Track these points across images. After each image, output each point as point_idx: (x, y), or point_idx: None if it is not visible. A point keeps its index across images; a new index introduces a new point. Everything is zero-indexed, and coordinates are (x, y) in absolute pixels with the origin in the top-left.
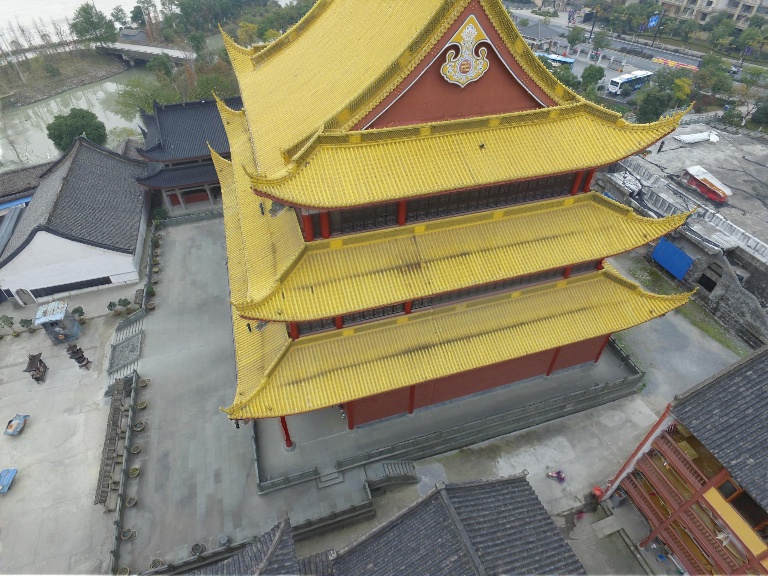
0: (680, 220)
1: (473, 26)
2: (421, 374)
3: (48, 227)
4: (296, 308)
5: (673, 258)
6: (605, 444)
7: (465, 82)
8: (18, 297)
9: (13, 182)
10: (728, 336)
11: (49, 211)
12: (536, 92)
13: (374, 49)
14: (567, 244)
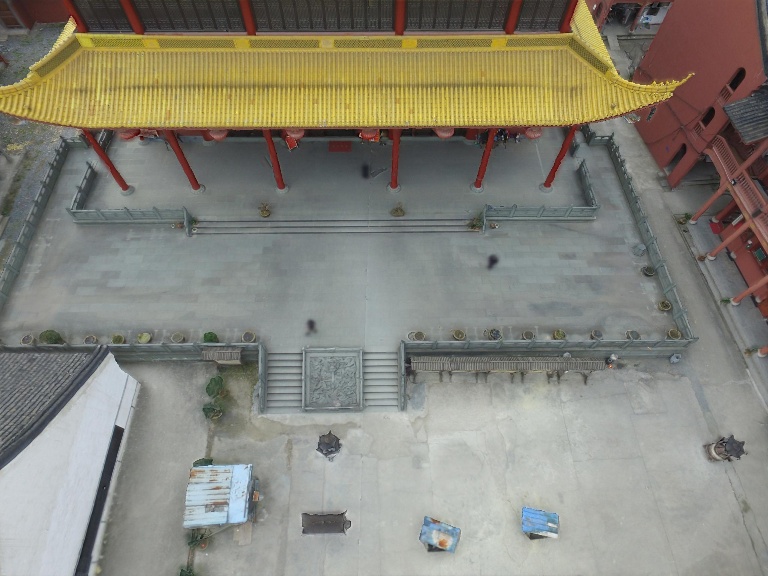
0: None
1: None
2: (581, 1)
3: None
4: None
5: None
6: None
7: None
8: None
9: None
10: None
11: None
12: None
13: None
14: None
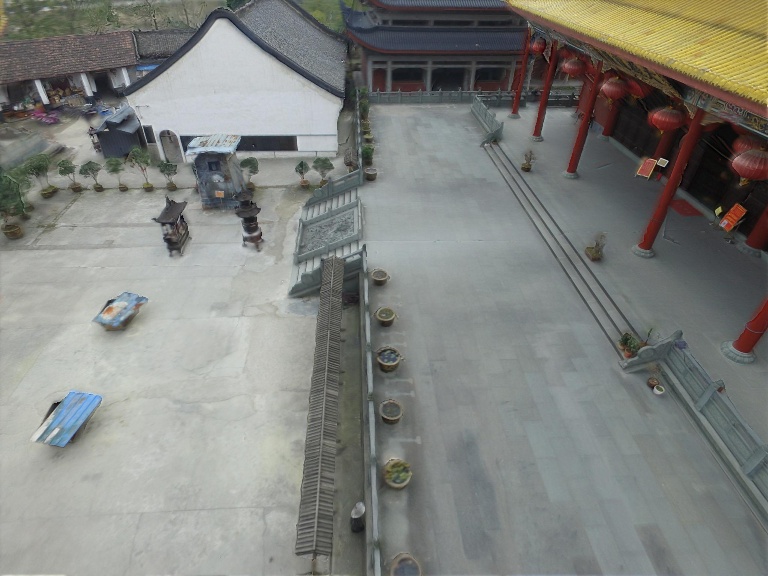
0: None
1: None
2: None
3: None
4: None
5: None
6: None
7: None
8: (161, 146)
9: (178, 43)
10: None
11: None
12: None
13: None
14: None
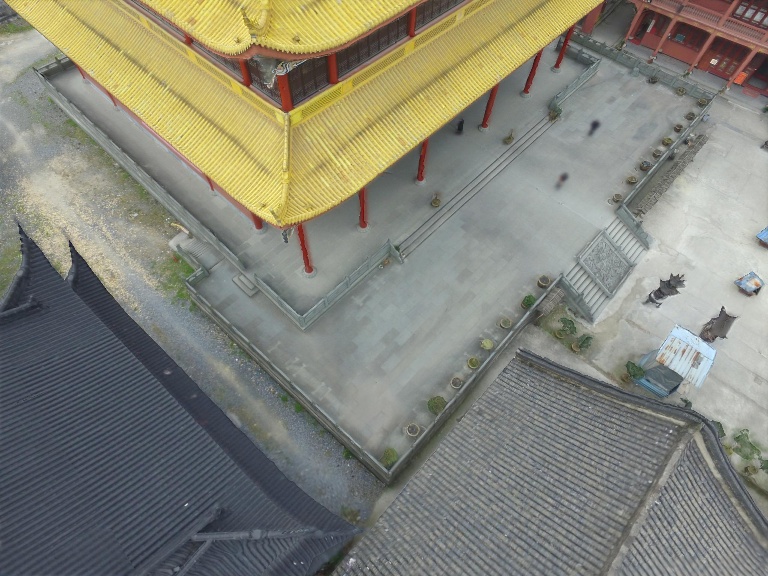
0: None
1: None
2: None
3: (681, 411)
4: None
5: None
6: None
7: None
8: None
9: None
10: None
11: (656, 498)
12: None
13: None
14: None
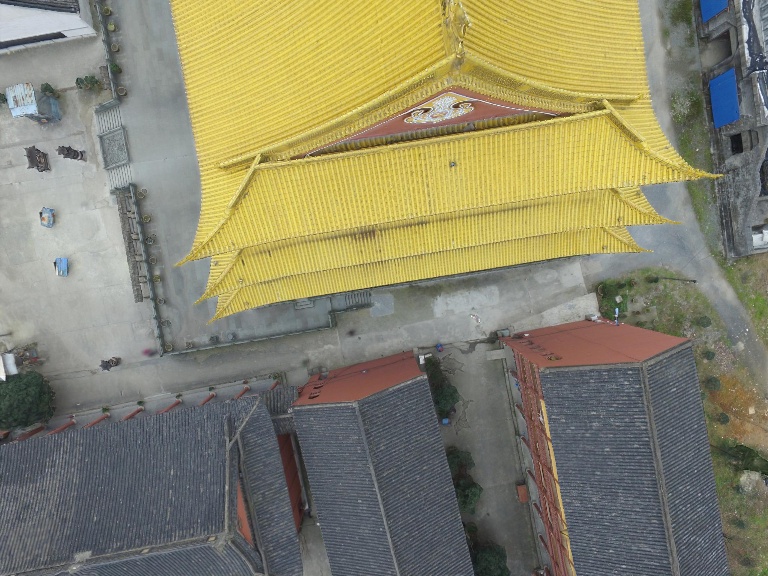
0: (660, 221)
1: (451, 96)
2: (372, 282)
3: None
4: (256, 272)
5: (725, 101)
6: (527, 297)
7: (439, 120)
8: None
9: None
10: (710, 207)
11: None
12: (542, 110)
13: (330, 1)
14: (534, 215)
